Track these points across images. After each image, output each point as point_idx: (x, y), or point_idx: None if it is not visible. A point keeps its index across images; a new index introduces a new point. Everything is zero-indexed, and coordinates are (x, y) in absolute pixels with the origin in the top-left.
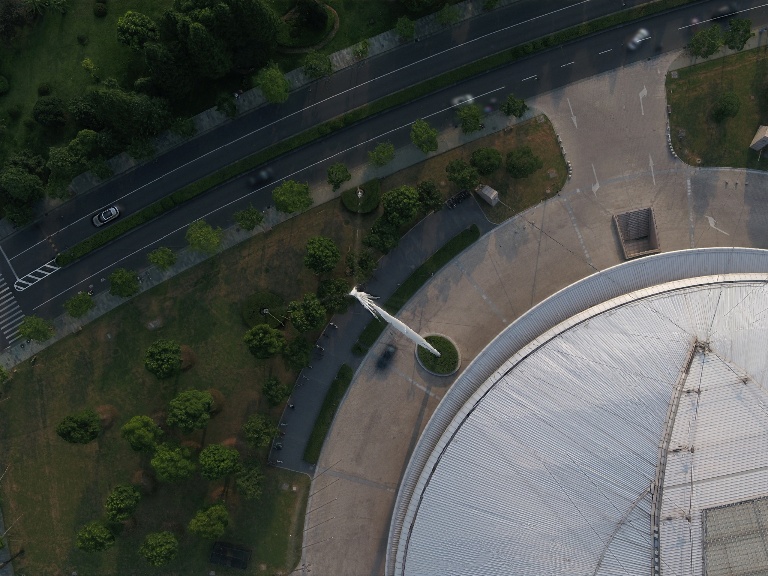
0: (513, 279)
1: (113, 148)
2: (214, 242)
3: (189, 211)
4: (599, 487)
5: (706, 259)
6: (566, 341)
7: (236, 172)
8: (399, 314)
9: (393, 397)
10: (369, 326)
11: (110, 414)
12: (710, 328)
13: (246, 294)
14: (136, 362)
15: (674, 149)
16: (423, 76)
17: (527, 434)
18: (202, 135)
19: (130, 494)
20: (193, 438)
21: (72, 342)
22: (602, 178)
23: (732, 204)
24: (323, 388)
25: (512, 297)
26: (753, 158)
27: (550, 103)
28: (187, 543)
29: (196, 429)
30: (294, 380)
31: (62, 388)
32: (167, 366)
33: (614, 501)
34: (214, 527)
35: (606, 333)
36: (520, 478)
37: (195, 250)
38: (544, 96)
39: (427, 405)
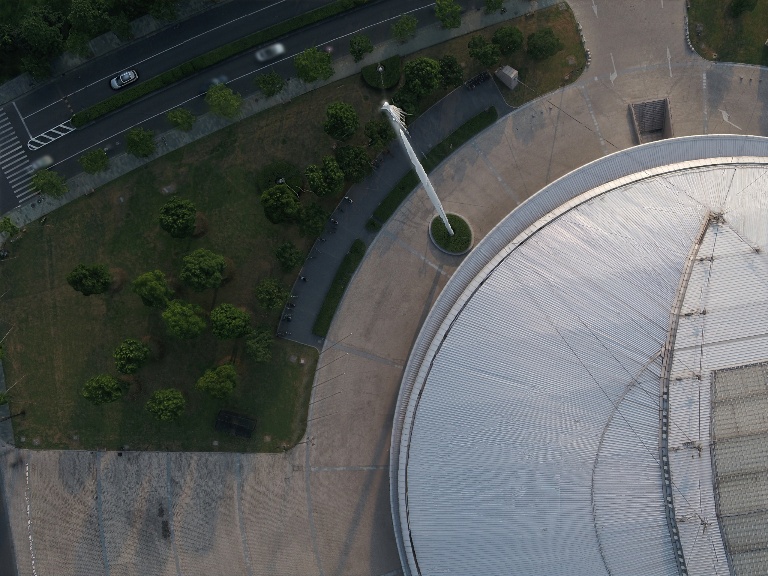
0: (529, 162)
1: (136, 5)
2: (234, 104)
3: (208, 78)
4: (610, 350)
5: (720, 145)
6: (581, 213)
7: (258, 41)
8: (414, 192)
9: (405, 274)
10: (384, 202)
11: (119, 277)
12: (724, 201)
13: (262, 164)
14: (148, 227)
15: (691, 43)
16: None
17: (540, 300)
18: (225, 3)
19: (139, 347)
20: (202, 306)
21: (84, 204)
22: (620, 67)
23: (746, 99)
24: (335, 262)
25: (527, 180)
26: (767, 55)
27: None
28: (191, 411)
29: (209, 286)
30: (306, 253)
31: (72, 249)
32: (182, 221)
33: (625, 364)
34: (223, 384)
35: (621, 206)
36: (532, 342)
37: (213, 118)
38: None
39: (438, 283)
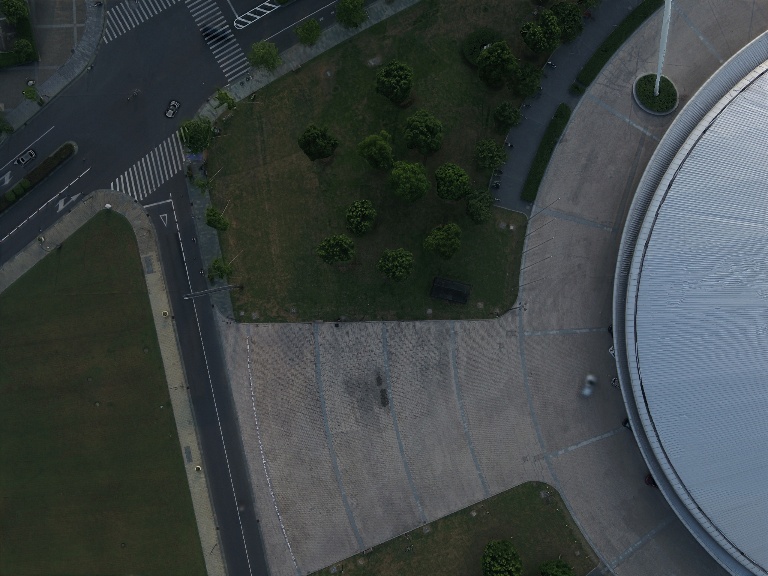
0: (730, 20)
1: None
2: None
3: None
4: None
5: None
6: None
7: None
8: (616, 55)
9: (610, 137)
10: (587, 65)
11: None
12: None
13: (465, 33)
14: (356, 99)
15: None
16: None
17: None
18: None
19: (371, 206)
20: None
21: (291, 80)
22: None
23: None
24: (540, 128)
25: (729, 38)
26: None
27: None
28: None
29: (434, 145)
30: None
31: (282, 125)
32: (405, 81)
33: None
34: (453, 240)
35: None
36: (766, 182)
37: None
38: None
39: (644, 145)
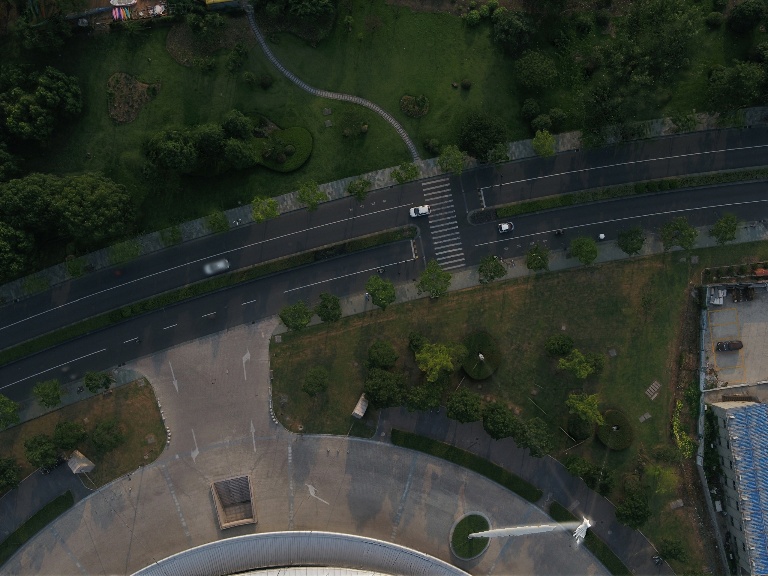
0: (108, 547)
1: None
2: None
3: None
4: None
5: (283, 543)
6: None
7: None
8: None
9: None
10: None
11: None
12: None
13: None
14: None
15: (276, 415)
16: (22, 337)
17: None
18: None
19: None
20: None
21: None
22: (202, 444)
23: (333, 472)
24: None
25: (106, 565)
26: (355, 426)
27: (151, 366)
28: None
29: None
30: None
31: None
32: None
33: None
34: None
35: None
36: None
37: None
38: (146, 359)
39: None
